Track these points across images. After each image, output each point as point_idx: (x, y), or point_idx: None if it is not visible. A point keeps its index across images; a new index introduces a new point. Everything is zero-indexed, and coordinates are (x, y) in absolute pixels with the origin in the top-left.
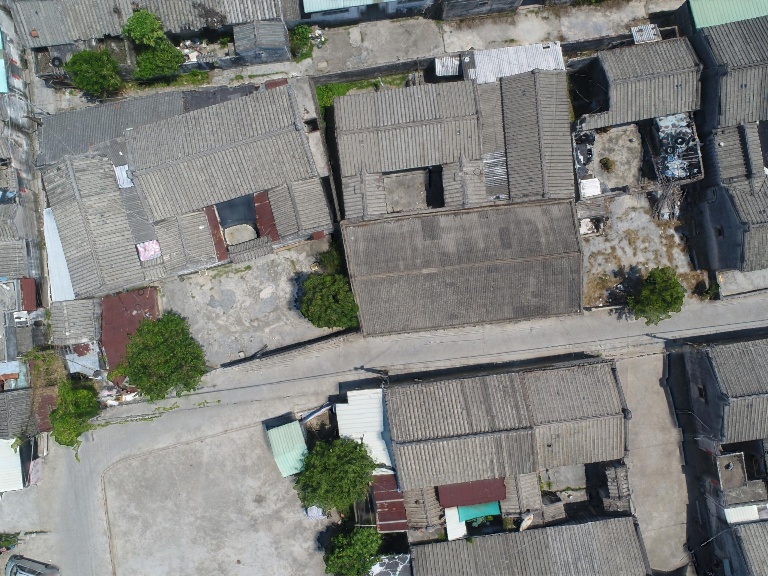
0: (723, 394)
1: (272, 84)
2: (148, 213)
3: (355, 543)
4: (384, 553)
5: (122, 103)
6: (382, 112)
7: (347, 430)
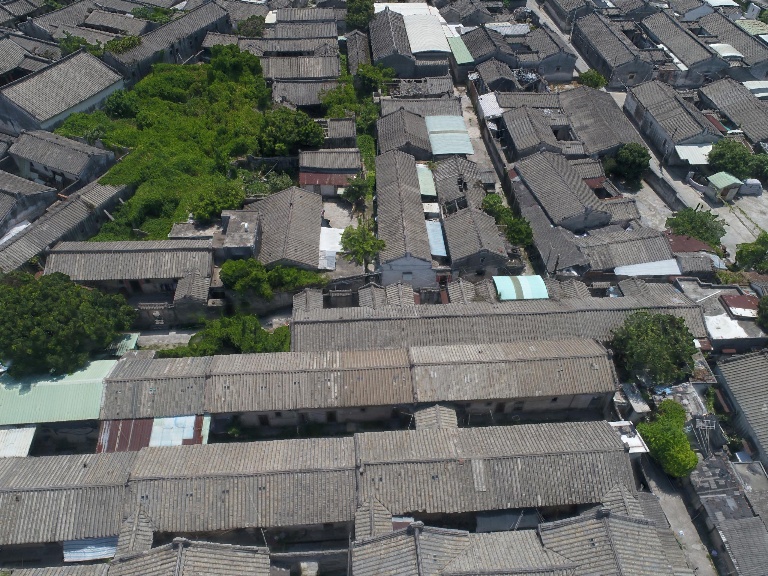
0: (635, 59)
1: (512, 175)
2: (608, 212)
3: (766, 159)
4: (765, 152)
5: (533, 234)
6: (526, 133)
7: (703, 160)
